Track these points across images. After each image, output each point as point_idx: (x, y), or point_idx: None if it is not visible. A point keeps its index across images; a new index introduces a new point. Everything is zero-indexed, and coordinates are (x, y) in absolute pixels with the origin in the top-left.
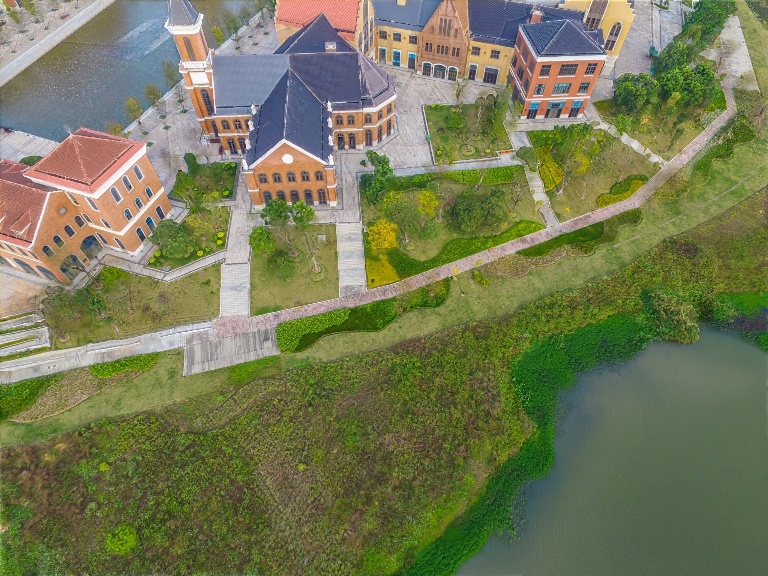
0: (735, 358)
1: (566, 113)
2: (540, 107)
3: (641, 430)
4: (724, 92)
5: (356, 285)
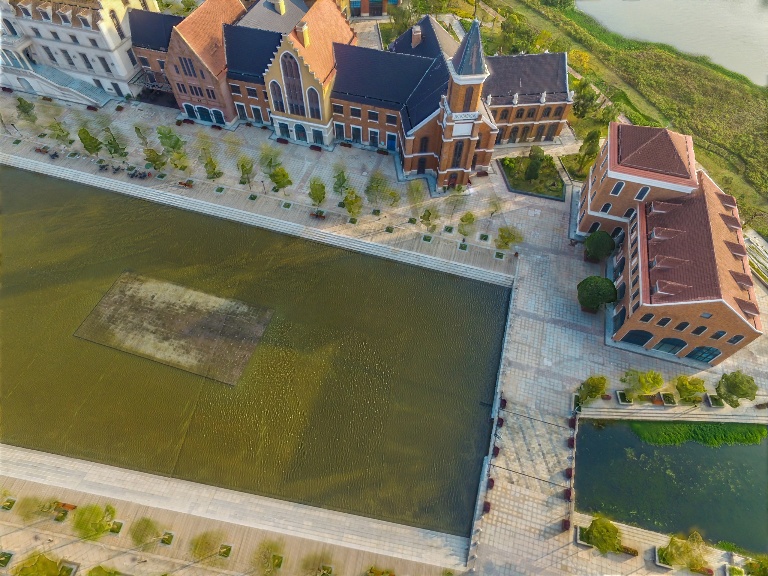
0: None
1: None
2: None
3: None
4: None
5: None
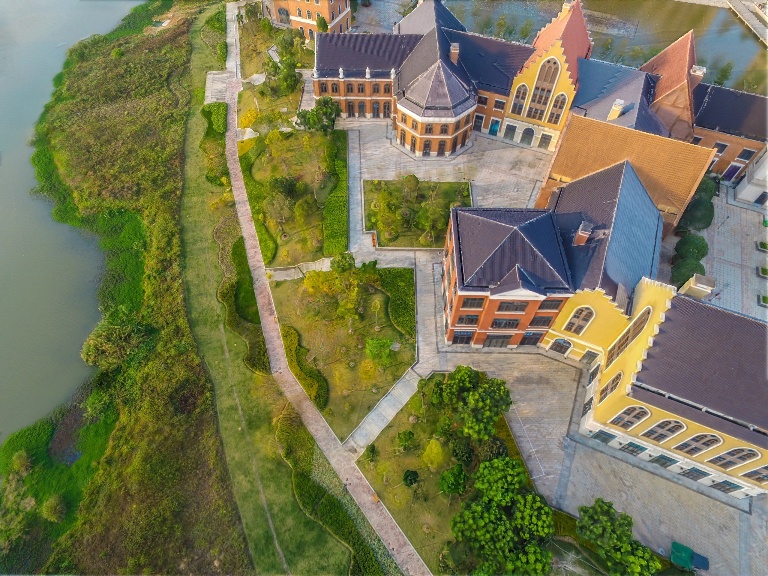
0: (47, 385)
1: None
2: None
3: (41, 279)
4: None
5: (244, 136)
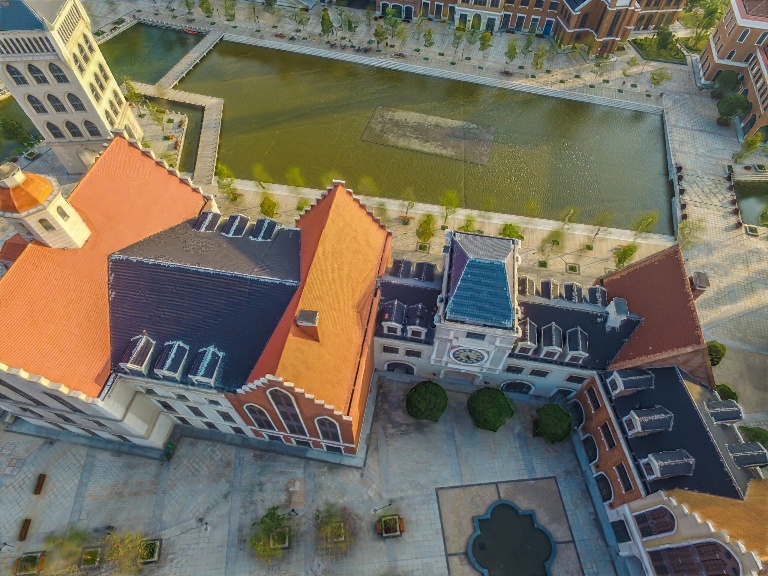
0: None
1: None
2: None
3: None
4: None
5: None
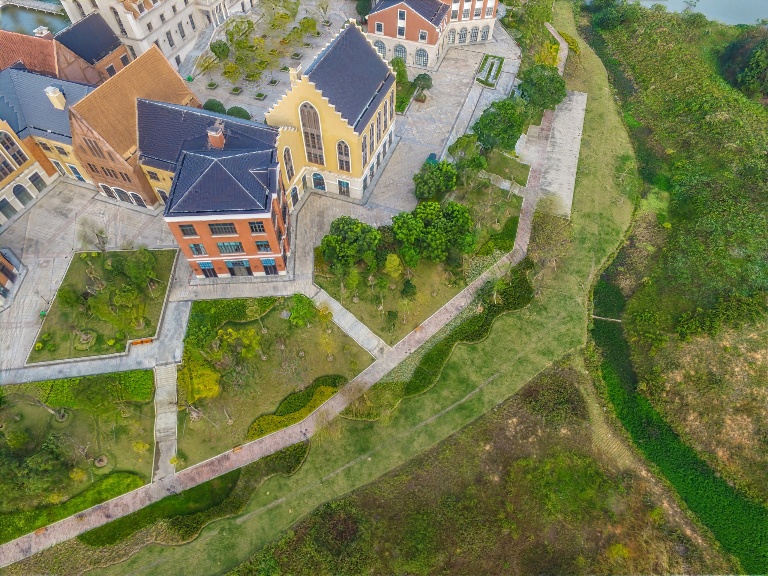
0: None
1: (260, 270)
2: (216, 266)
3: None
4: (521, 218)
5: None
